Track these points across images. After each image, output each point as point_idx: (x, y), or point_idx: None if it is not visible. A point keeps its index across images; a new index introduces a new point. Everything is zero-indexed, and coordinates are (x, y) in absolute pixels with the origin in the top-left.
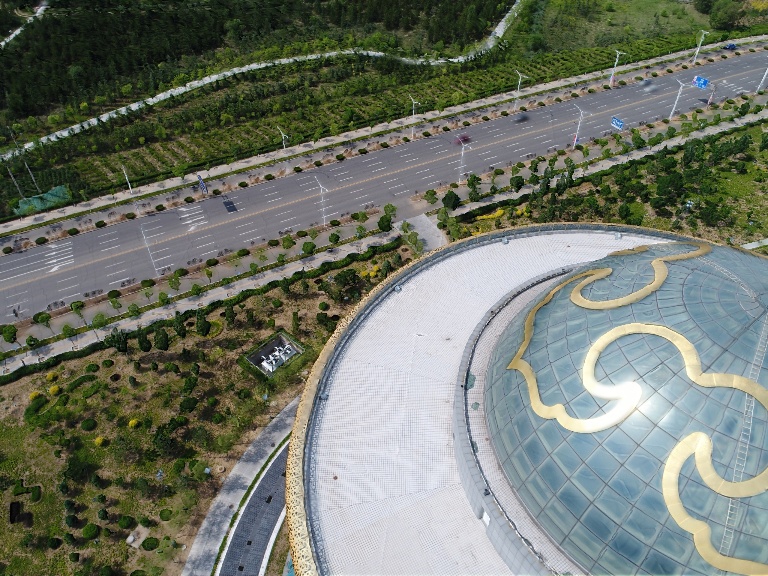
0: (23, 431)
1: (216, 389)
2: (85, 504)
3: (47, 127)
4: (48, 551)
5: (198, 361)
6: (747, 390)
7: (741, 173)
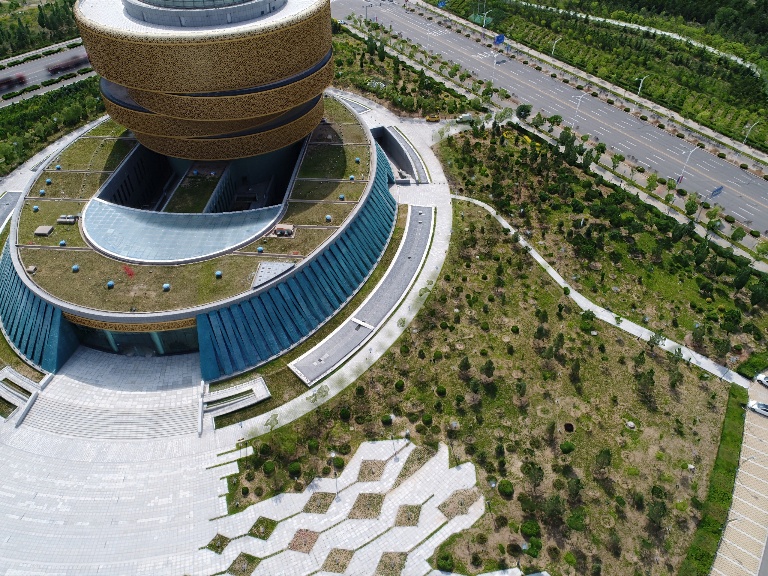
0: None
1: None
2: None
3: None
4: None
5: None
6: None
7: (702, 294)
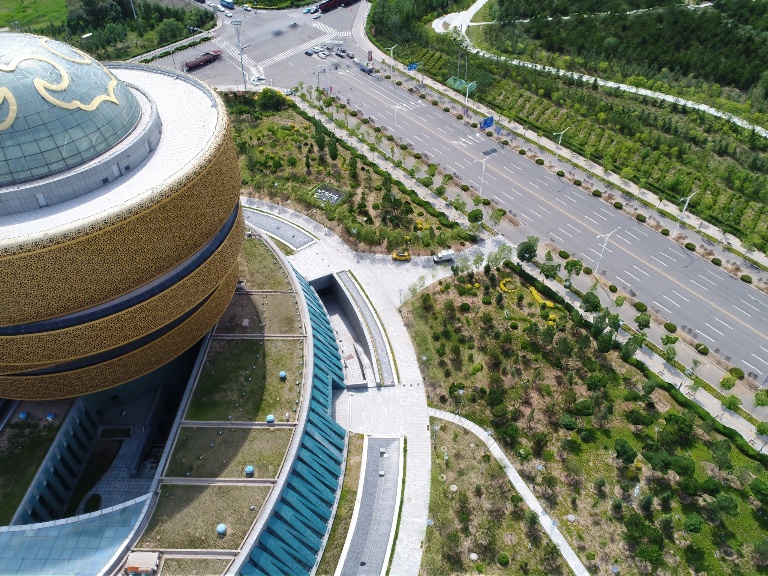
0: None
1: (298, 178)
2: None
3: (541, 60)
4: None
5: None
6: None
7: None
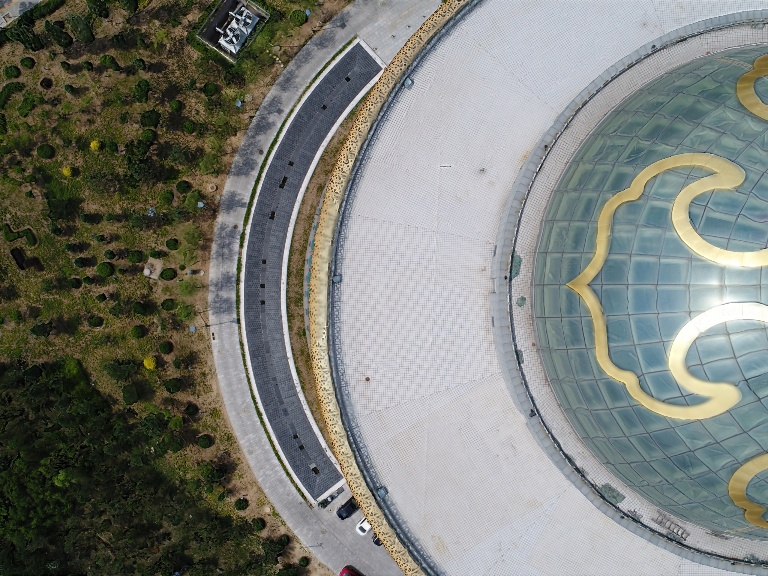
0: None
1: (174, 87)
2: (86, 242)
3: None
4: (73, 291)
5: (139, 47)
6: None
7: None
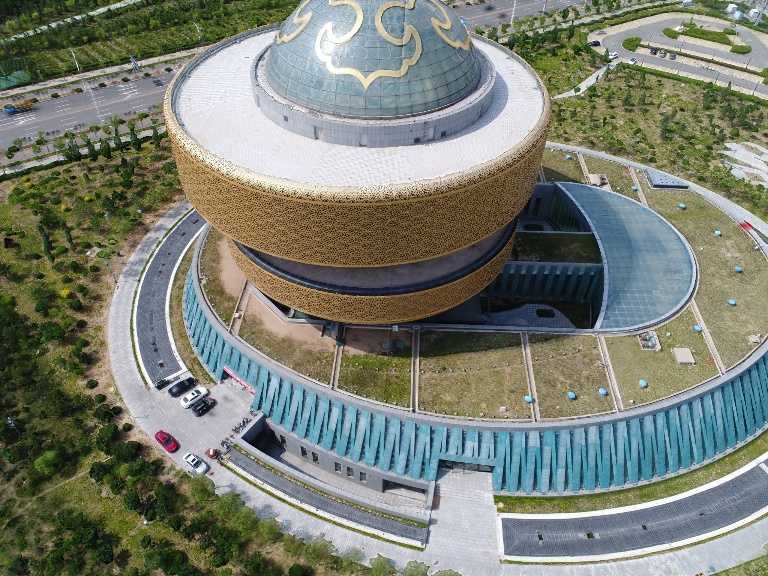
0: (8, 207)
1: (147, 182)
2: (56, 239)
3: (5, 33)
4: (33, 261)
5: None
6: (349, 4)
7: (553, 56)
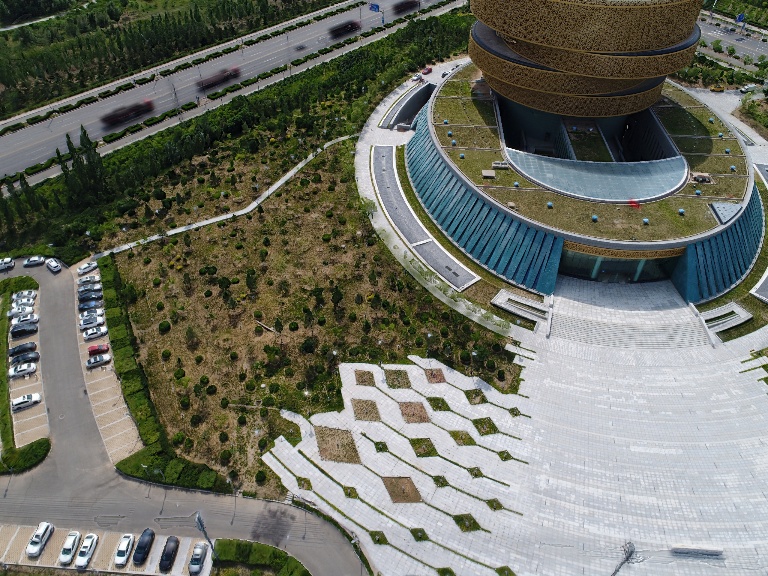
0: None
1: None
2: None
3: None
4: None
5: None
6: None
7: None
